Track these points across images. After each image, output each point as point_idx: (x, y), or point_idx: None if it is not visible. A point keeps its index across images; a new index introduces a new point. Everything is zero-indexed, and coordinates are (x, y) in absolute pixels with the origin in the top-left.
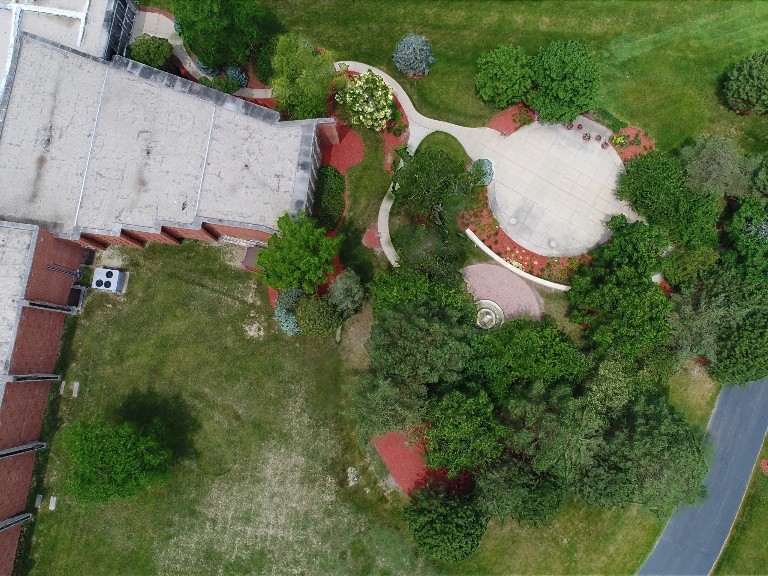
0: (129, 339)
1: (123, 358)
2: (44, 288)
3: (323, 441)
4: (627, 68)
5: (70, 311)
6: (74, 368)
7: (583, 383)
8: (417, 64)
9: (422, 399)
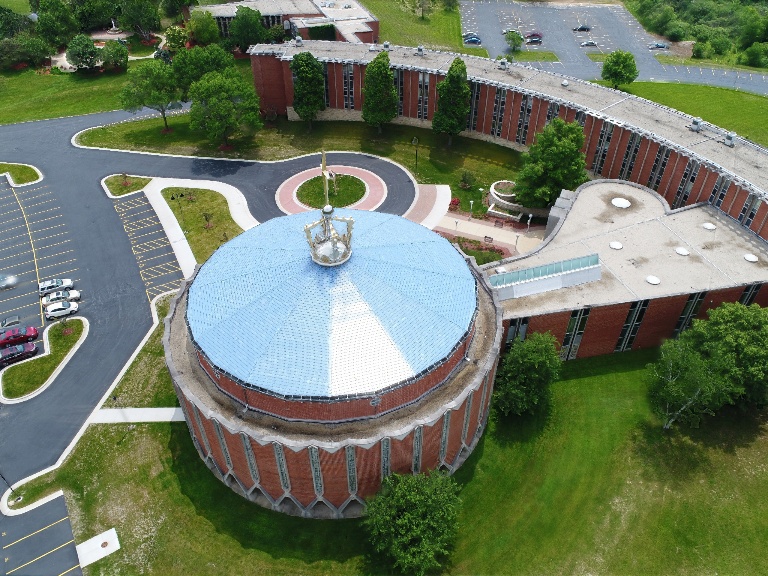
0: None
1: None
2: None
3: None
4: None
5: None
6: None
7: None
8: None
9: None
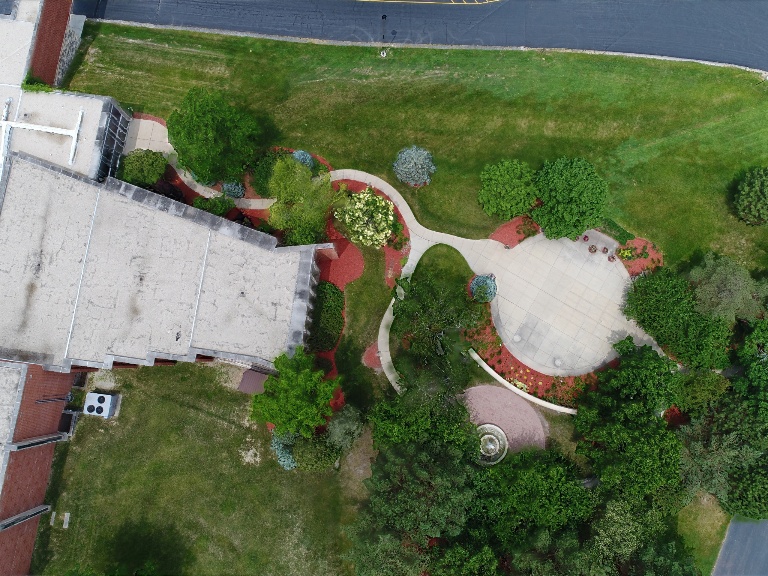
0: (121, 466)
1: (115, 486)
2: (33, 423)
3: (321, 574)
4: (634, 175)
5: (61, 438)
6: (65, 497)
7: (590, 522)
8: (418, 176)
9: (423, 553)
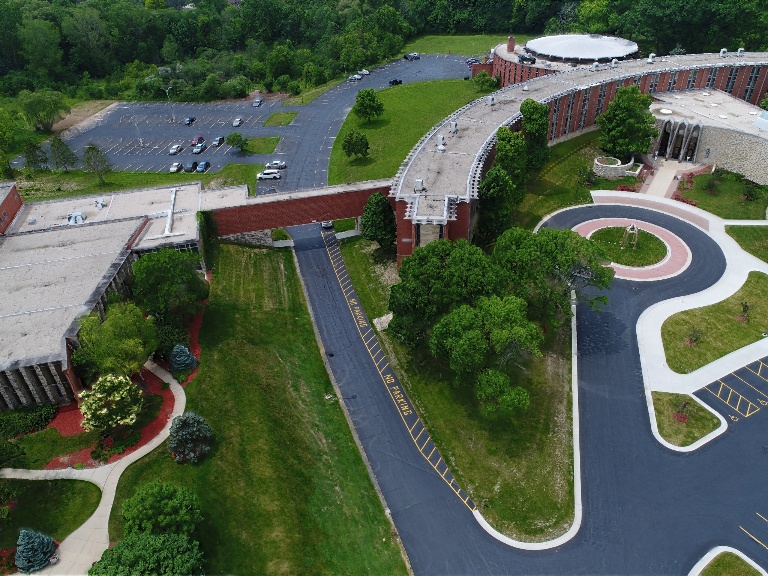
0: None
1: None
2: None
3: None
4: None
5: None
6: None
7: None
8: None
9: None
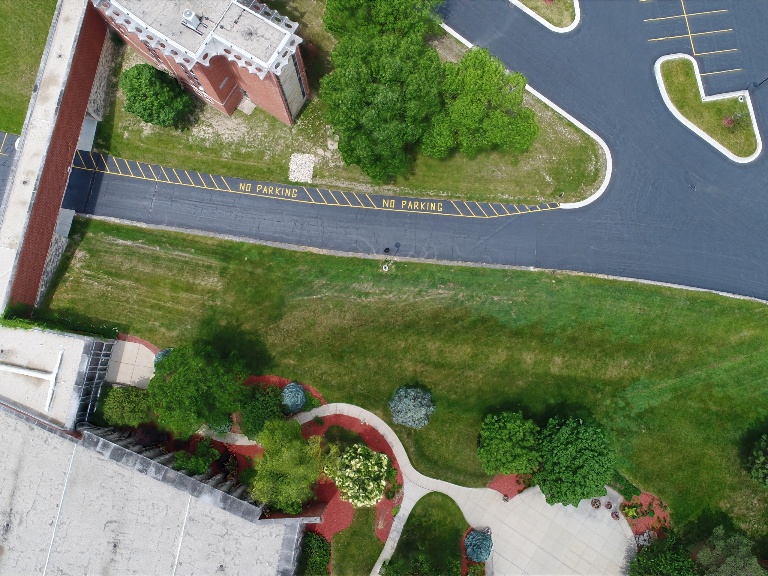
0: None
1: None
2: None
3: None
4: (643, 421)
5: None
6: None
7: None
8: (415, 423)
9: None
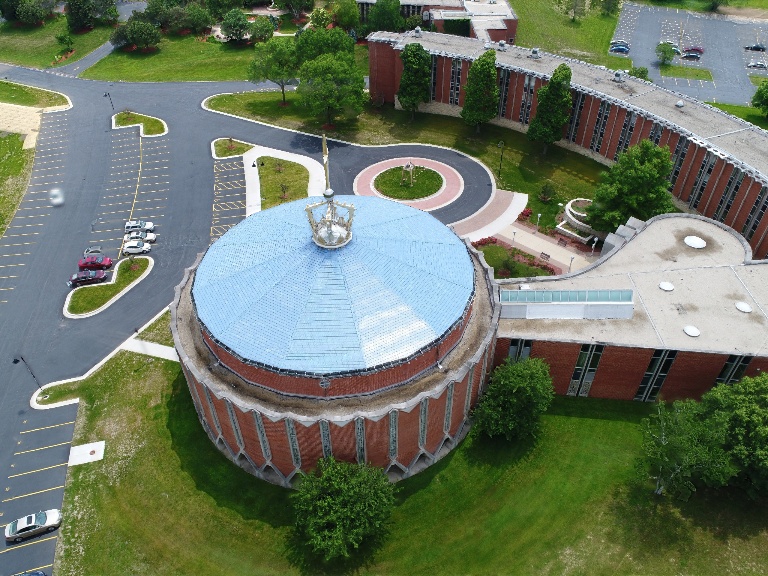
0: None
1: None
2: None
3: None
4: None
5: None
6: None
7: None
8: None
9: None
